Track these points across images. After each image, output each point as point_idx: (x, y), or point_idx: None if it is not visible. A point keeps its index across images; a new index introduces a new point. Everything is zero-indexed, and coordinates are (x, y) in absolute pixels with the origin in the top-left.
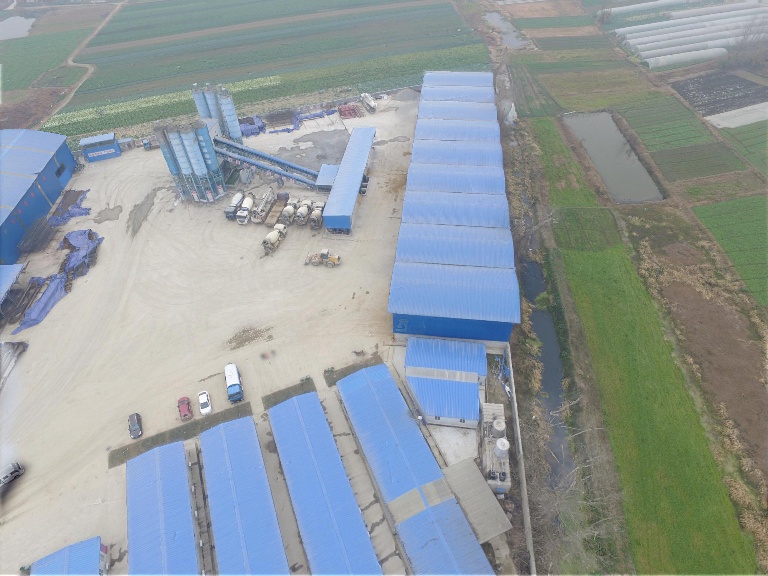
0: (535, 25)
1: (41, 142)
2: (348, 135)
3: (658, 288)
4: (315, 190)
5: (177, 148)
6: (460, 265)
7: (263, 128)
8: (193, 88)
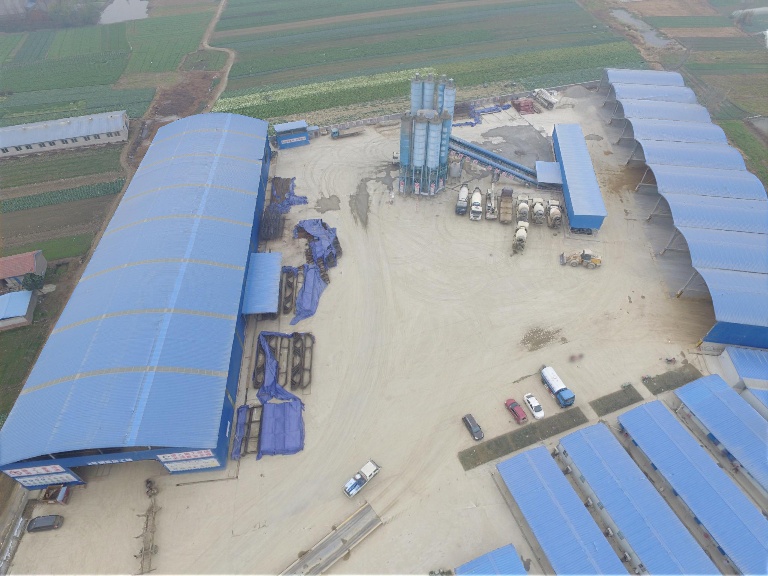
0: (671, 24)
1: (250, 127)
2: (536, 131)
3: None
4: (532, 187)
5: (421, 139)
6: (765, 273)
7: None
8: (350, 77)
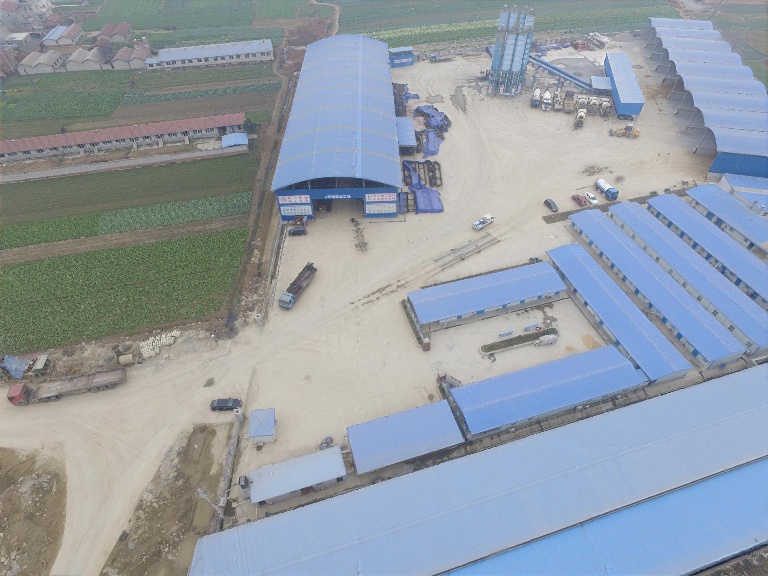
0: None
1: (377, 45)
2: (590, 62)
3: None
4: (588, 94)
5: (510, 47)
6: None
7: None
8: (437, 24)
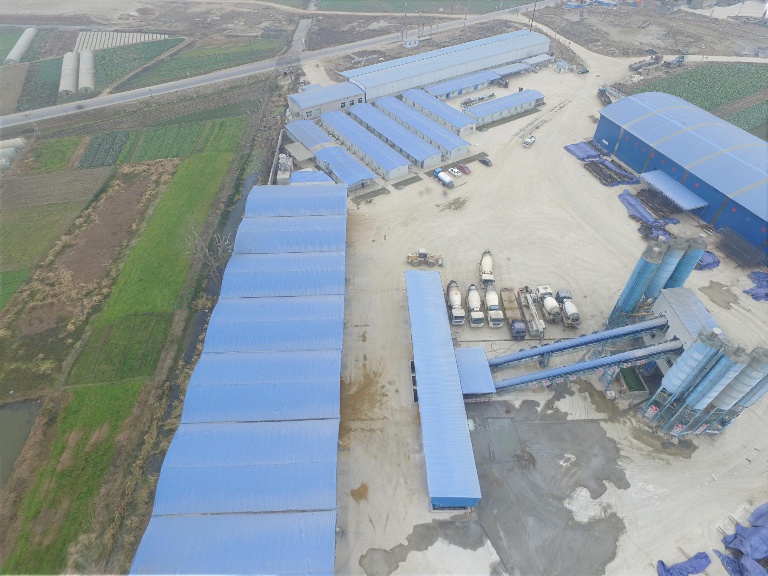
0: None
1: None
2: (511, 567)
3: (106, 278)
4: None
5: None
6: (290, 216)
7: (741, 575)
8: None
